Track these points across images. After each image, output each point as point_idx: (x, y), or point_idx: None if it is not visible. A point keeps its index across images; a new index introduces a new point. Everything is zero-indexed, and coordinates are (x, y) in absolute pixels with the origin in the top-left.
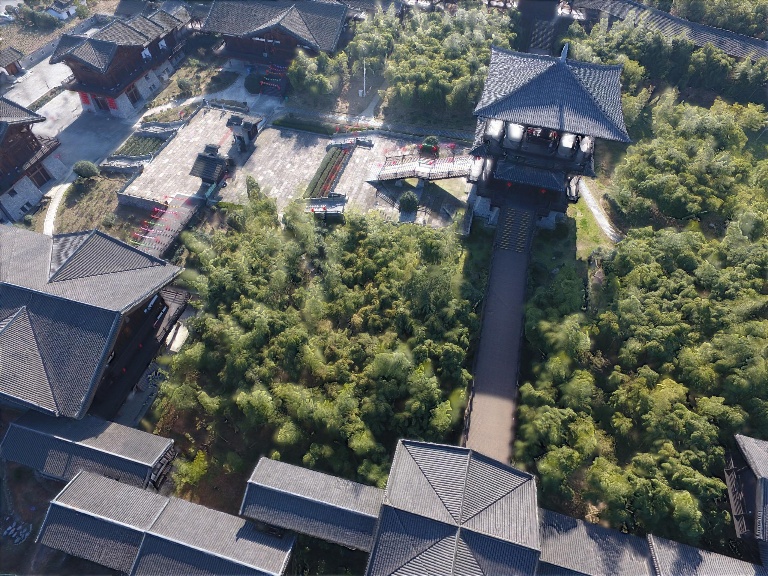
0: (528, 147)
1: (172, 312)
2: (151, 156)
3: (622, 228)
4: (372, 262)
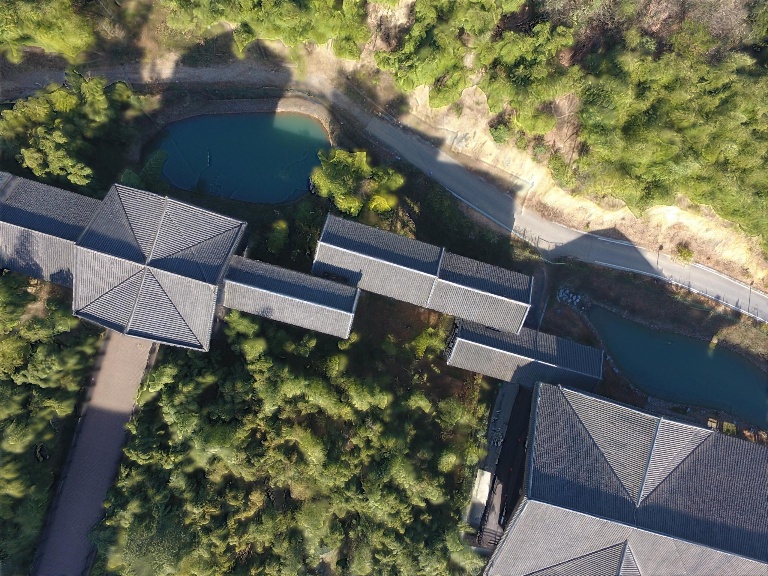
0: None
1: (494, 517)
2: None
3: None
4: None
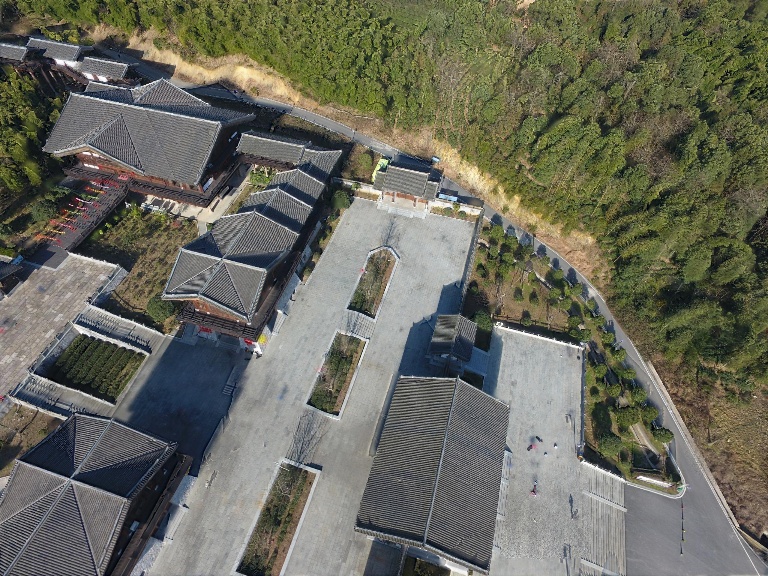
0: None
1: None
2: (75, 324)
3: None
4: None
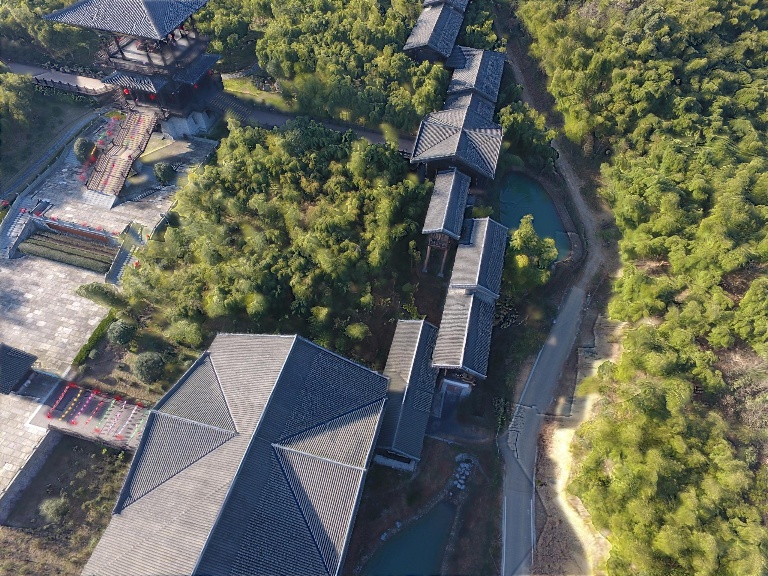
0: None
1: None
2: None
3: (235, 69)
4: (257, 174)
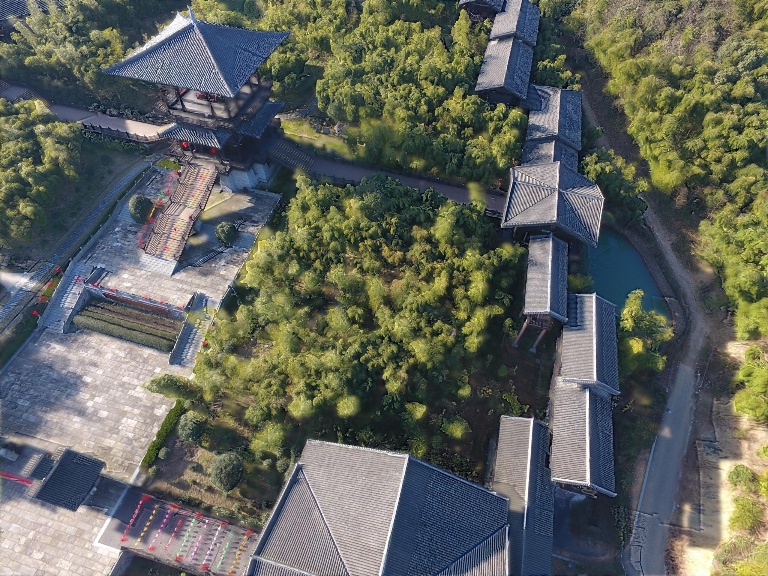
0: (235, 105)
1: None
2: None
3: (289, 109)
4: (335, 242)
